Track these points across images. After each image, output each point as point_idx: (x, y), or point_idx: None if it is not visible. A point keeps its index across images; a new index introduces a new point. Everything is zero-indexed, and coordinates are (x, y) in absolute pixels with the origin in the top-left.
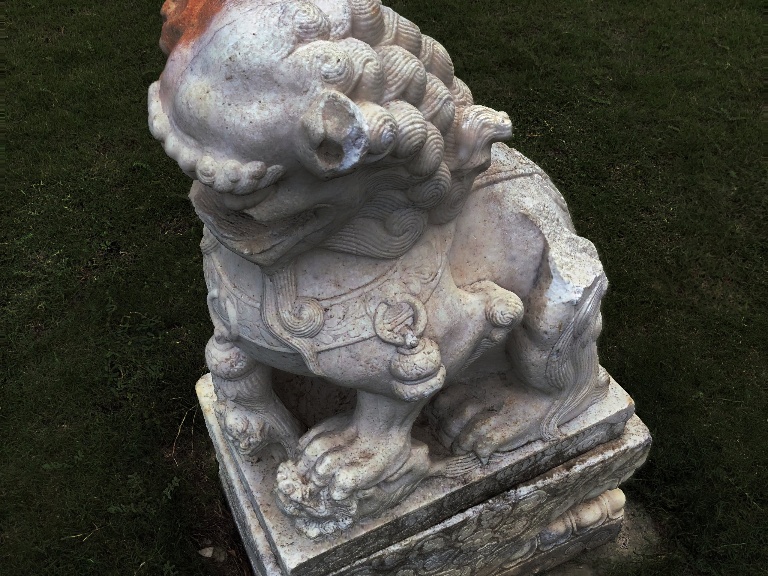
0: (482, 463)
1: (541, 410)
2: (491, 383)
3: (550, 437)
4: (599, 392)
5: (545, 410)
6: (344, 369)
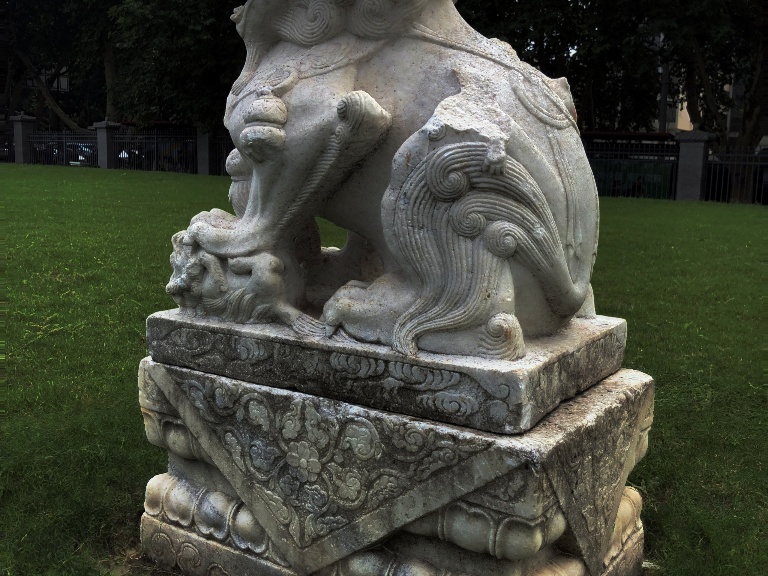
0: (326, 333)
1: (400, 302)
2: (390, 271)
3: (398, 345)
4: (492, 344)
5: (405, 305)
6: None
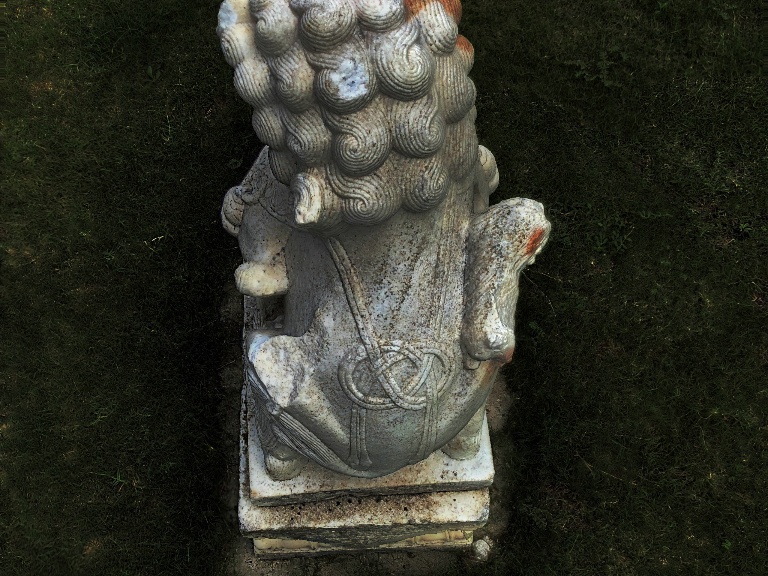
0: None
1: None
2: None
3: None
4: None
5: None
6: None
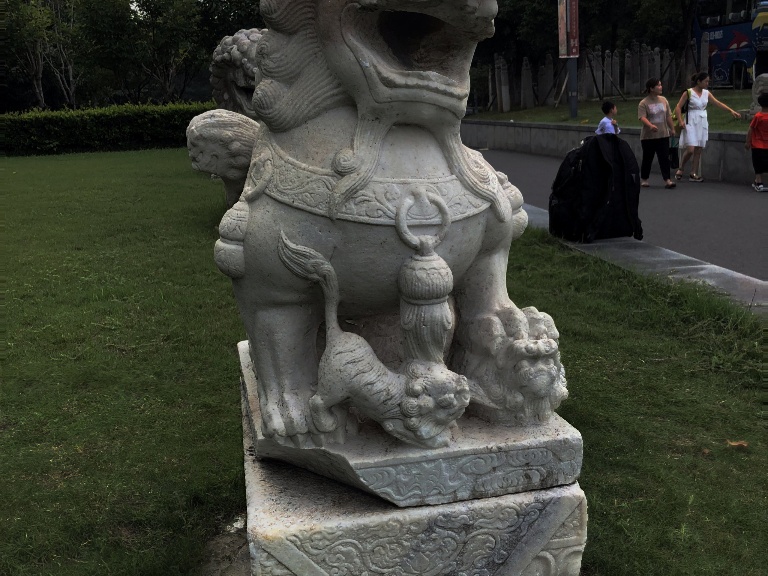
0: None
1: None
2: None
3: None
4: None
5: None
6: (507, 208)
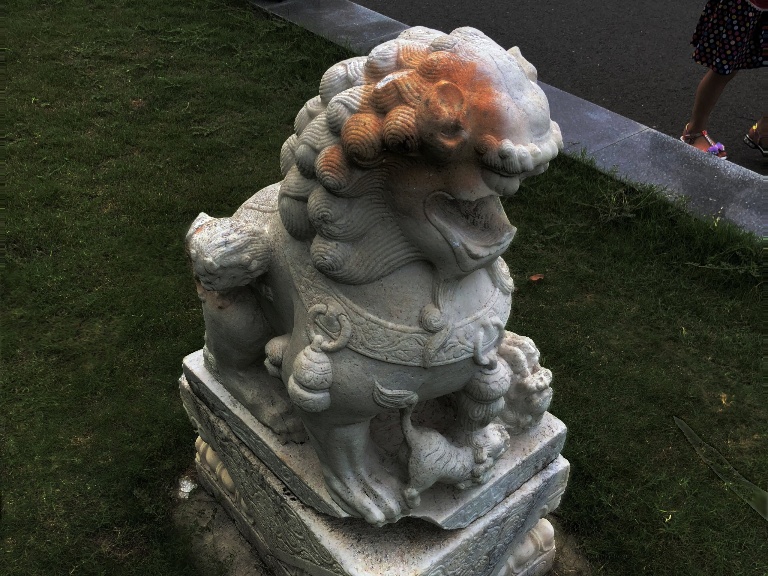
0: None
1: None
2: None
3: None
4: None
5: None
6: None
